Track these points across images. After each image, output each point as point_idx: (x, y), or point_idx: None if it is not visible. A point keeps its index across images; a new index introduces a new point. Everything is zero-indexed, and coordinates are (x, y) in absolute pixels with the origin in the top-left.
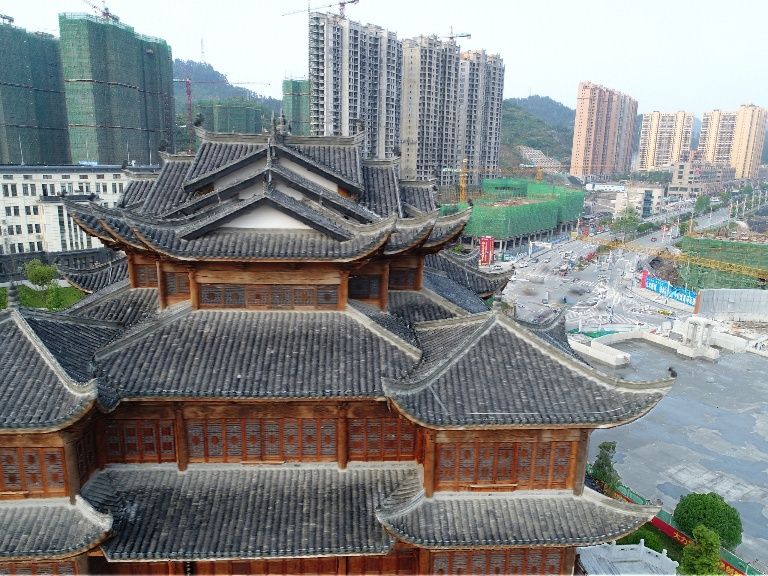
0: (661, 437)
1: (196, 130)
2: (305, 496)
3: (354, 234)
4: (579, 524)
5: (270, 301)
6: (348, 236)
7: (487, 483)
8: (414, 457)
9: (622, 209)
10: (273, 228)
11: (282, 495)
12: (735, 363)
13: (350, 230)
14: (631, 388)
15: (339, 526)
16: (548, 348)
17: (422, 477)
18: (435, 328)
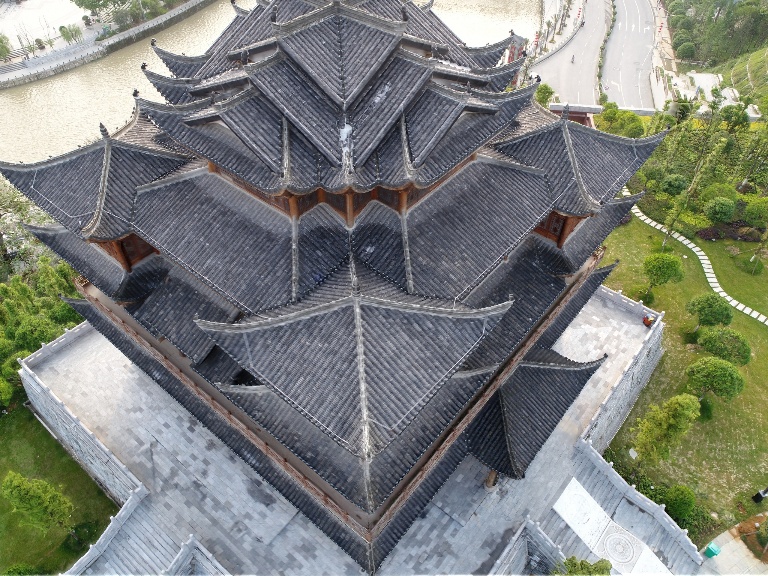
0: None
1: None
2: None
3: None
4: None
5: None
6: None
7: None
8: None
9: None
10: None
11: None
12: None
13: None
14: None
15: None
16: None
17: None
18: None
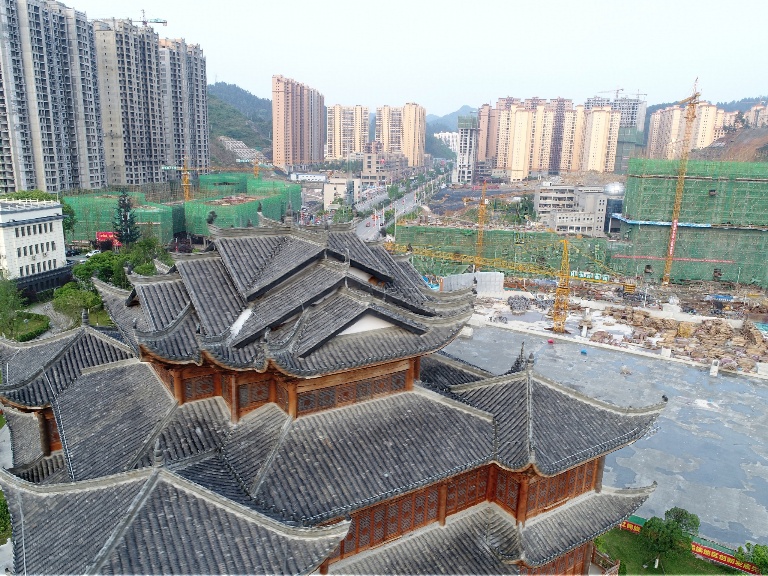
0: None
1: None
2: (434, 559)
3: (428, 327)
4: (609, 513)
5: (355, 395)
6: (426, 330)
7: (552, 503)
8: (485, 498)
9: (344, 203)
10: (363, 331)
11: (417, 565)
12: (484, 337)
13: (421, 323)
14: (637, 413)
15: (476, 574)
16: (575, 393)
17: (504, 513)
18: (472, 389)
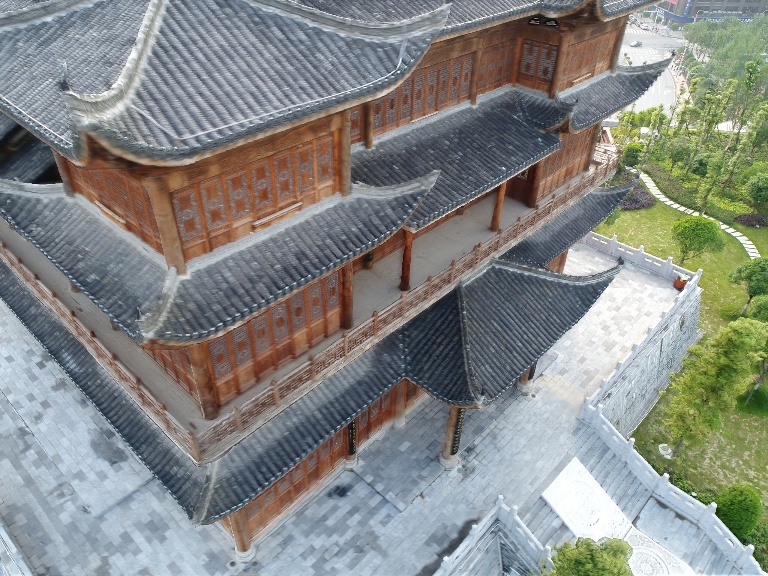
0: None
1: None
2: None
3: None
4: None
5: None
6: None
7: None
8: None
9: None
10: None
11: None
12: None
13: None
14: None
15: None
16: None
17: None
18: None
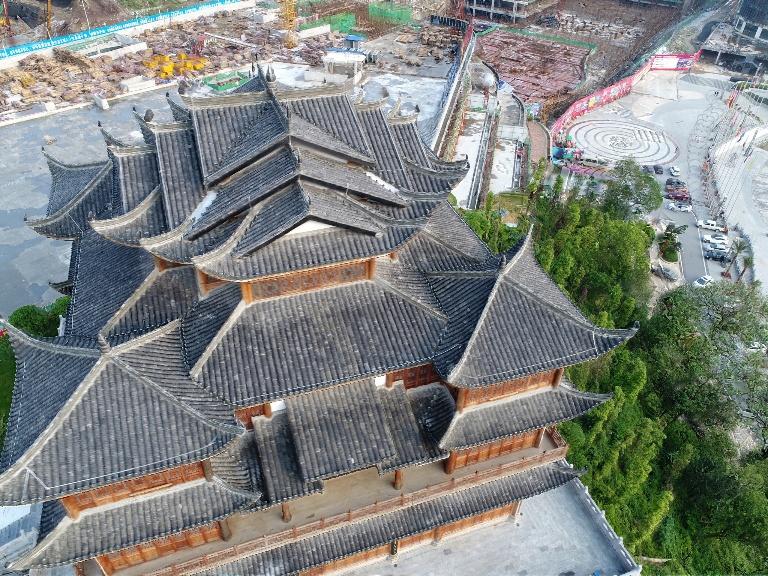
0: (4, 259)
1: (290, 122)
2: None
3: None
4: None
5: None
6: None
7: None
8: None
9: None
10: None
11: None
12: None
13: None
14: None
15: None
16: None
17: None
18: None
